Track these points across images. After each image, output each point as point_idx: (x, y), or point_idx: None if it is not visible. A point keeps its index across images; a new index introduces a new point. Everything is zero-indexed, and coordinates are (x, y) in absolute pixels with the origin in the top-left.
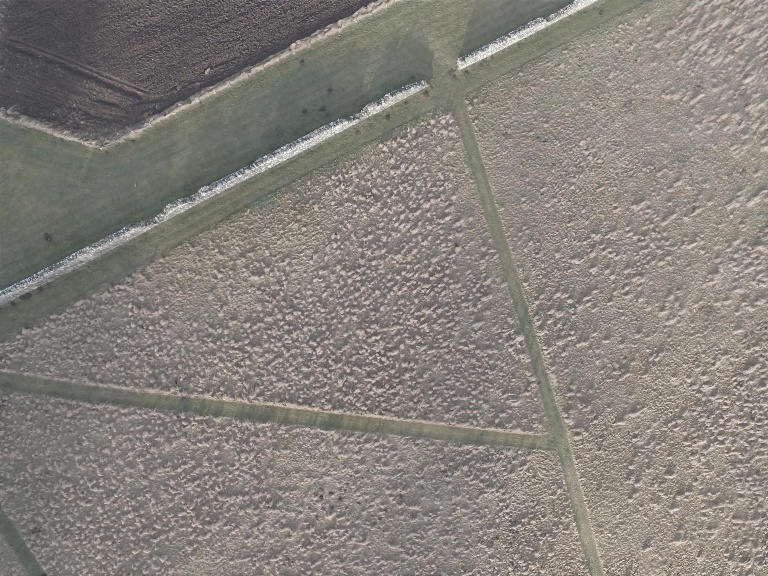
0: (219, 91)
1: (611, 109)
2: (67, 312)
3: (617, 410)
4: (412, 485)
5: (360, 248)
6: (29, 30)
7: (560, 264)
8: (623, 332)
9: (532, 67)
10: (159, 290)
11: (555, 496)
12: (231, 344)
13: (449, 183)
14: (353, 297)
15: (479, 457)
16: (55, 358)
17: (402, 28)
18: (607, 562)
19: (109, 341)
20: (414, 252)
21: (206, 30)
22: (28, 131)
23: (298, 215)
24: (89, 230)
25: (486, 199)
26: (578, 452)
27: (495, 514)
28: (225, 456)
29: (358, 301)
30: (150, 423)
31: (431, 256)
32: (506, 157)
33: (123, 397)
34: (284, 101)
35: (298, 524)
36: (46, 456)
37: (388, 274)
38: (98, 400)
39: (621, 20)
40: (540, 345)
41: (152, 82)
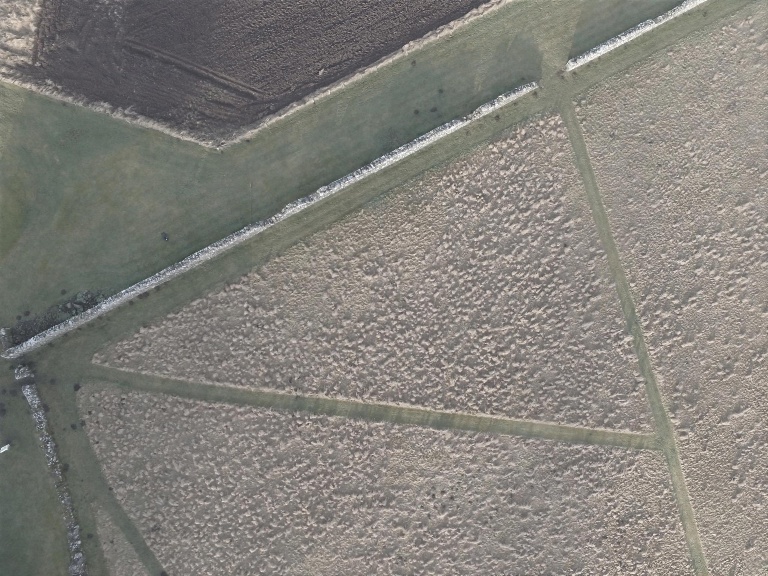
0: (333, 92)
1: (715, 111)
2: (184, 311)
3: (721, 410)
4: (522, 484)
5: (471, 248)
6: (146, 31)
7: (666, 265)
8: (727, 333)
9: (638, 69)
10: (274, 289)
11: (662, 496)
12: (345, 343)
13: (558, 184)
14: (464, 297)
15: (588, 457)
16: (172, 357)
17: (512, 30)
18: (712, 562)
19: (225, 340)
20: (524, 252)
21: (320, 31)
22: (145, 131)
23: (411, 215)
24: (206, 230)
25: (594, 200)
26: (684, 452)
27: (603, 513)
28: (339, 455)
29: (469, 301)
30: (265, 422)
31: (541, 256)
32: (613, 158)
33: (239, 396)
34: (396, 102)
35: (410, 523)
36: (164, 454)
37: (499, 274)
38: (214, 399)
39: (725, 22)
40: (647, 345)
41: (267, 83)
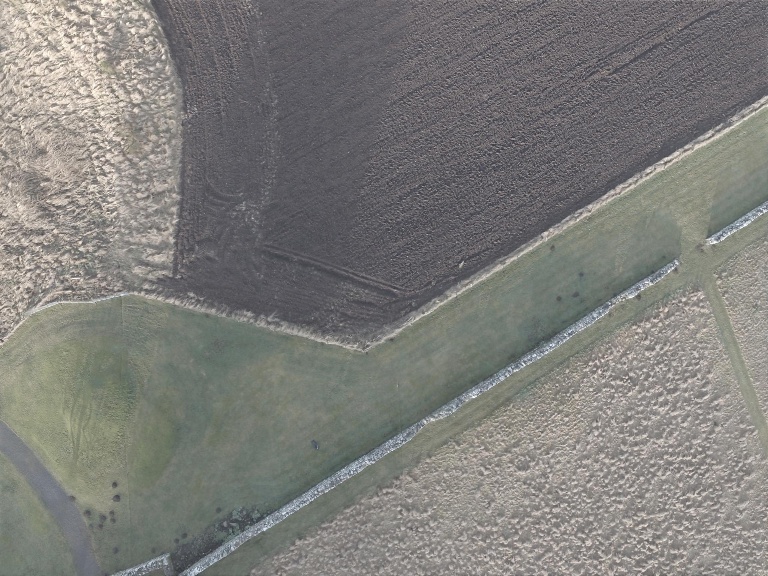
0: (475, 284)
1: None
2: (338, 519)
3: None
4: None
5: (622, 434)
6: (284, 234)
7: None
8: None
9: None
10: (427, 491)
11: None
12: (500, 541)
13: (704, 361)
14: (618, 485)
15: None
16: (329, 567)
17: (649, 206)
18: None
19: (380, 546)
20: (675, 435)
21: (458, 223)
22: (289, 338)
23: (561, 406)
24: (356, 435)
25: (740, 373)
26: None
27: None
28: None
29: (623, 488)
30: None
31: (692, 437)
32: (757, 329)
33: None
34: (538, 289)
35: None
36: None
37: (651, 459)
38: None
39: None
40: None
41: (408, 279)
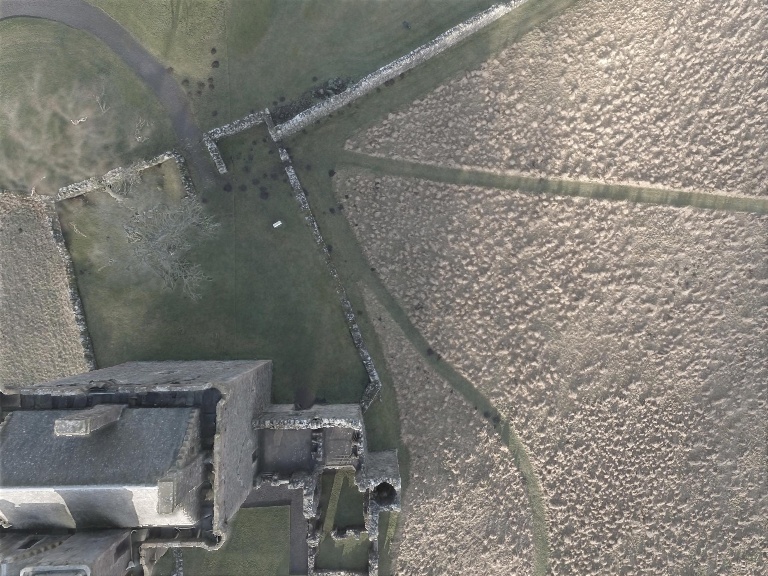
0: None
1: None
2: (428, 98)
3: None
4: (759, 260)
5: (697, 32)
6: None
7: None
8: None
9: None
10: (513, 75)
11: None
12: (583, 126)
13: None
14: (693, 79)
15: None
16: (421, 142)
17: None
18: None
19: (469, 126)
20: (746, 35)
21: None
22: None
23: None
24: (446, 17)
25: None
26: None
27: None
28: (585, 235)
29: (698, 83)
30: (513, 204)
31: (762, 39)
32: None
33: (485, 180)
34: None
35: (657, 300)
36: (421, 236)
37: (724, 57)
38: (463, 183)
39: None
40: None
41: None
